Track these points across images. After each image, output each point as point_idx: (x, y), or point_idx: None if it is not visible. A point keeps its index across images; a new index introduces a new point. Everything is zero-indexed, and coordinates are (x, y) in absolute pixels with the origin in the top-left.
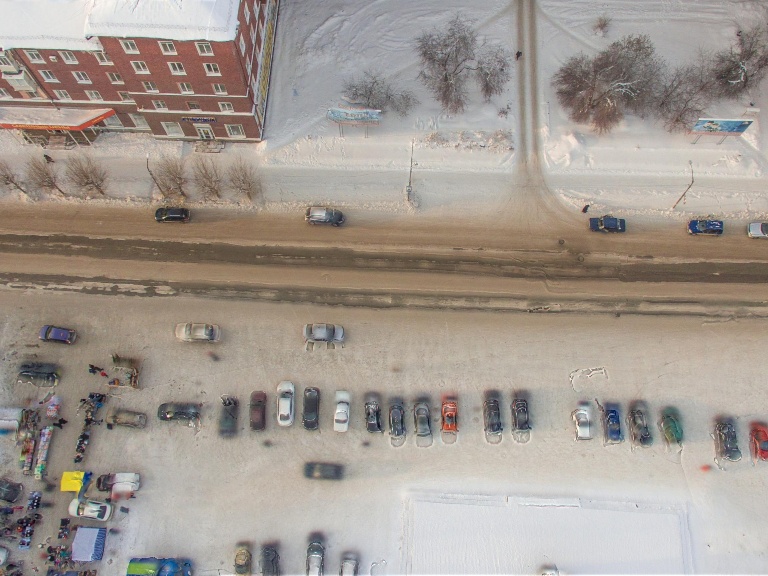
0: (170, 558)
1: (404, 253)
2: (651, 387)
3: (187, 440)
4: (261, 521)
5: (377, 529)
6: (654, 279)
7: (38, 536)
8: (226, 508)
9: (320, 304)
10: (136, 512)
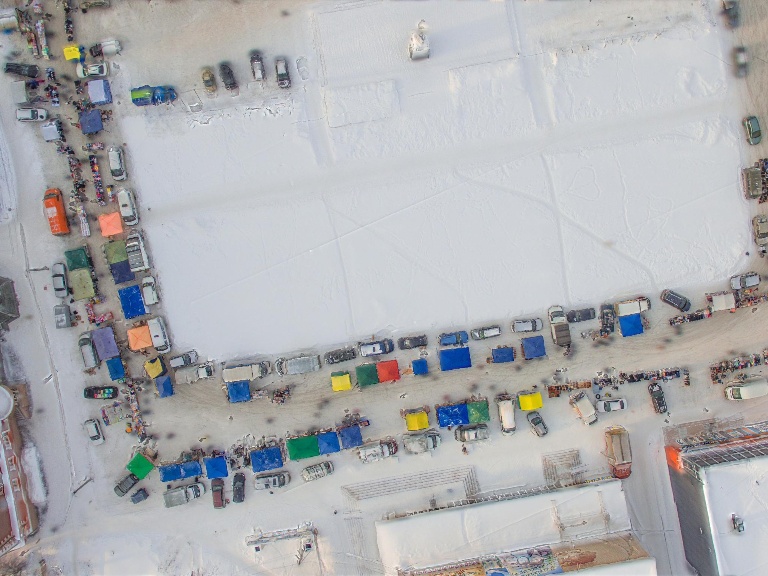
0: (158, 86)
1: None
2: None
3: (144, 9)
4: (214, 52)
5: (296, 39)
6: None
7: (63, 97)
8: (187, 49)
9: None
10: (125, 66)
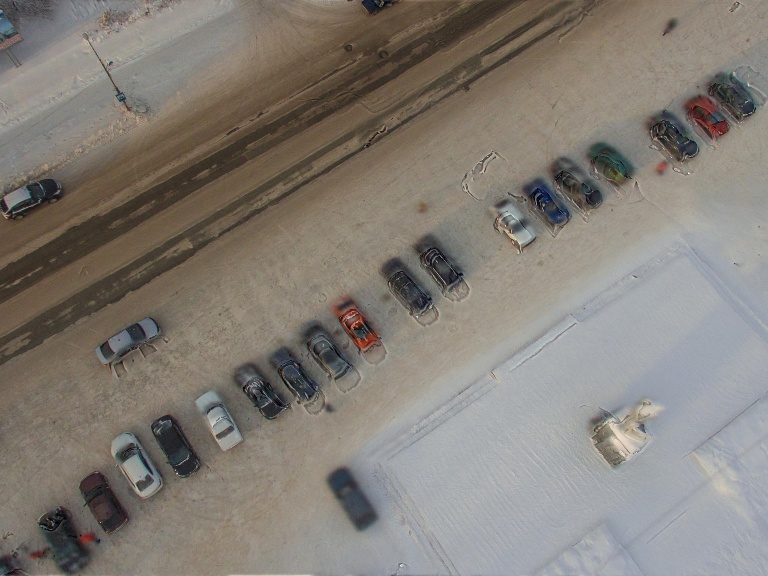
0: None
1: (169, 179)
2: (556, 141)
3: None
4: None
5: (365, 532)
6: (476, 29)
7: None
8: None
9: (100, 310)
10: None
